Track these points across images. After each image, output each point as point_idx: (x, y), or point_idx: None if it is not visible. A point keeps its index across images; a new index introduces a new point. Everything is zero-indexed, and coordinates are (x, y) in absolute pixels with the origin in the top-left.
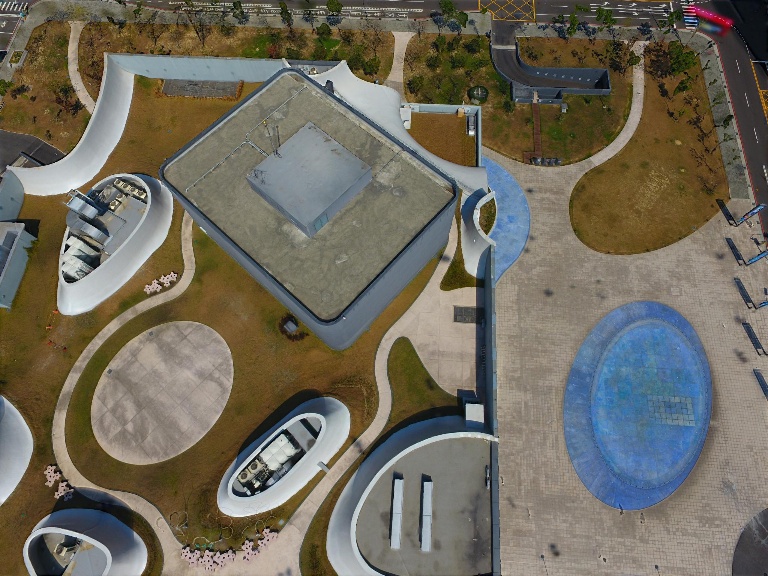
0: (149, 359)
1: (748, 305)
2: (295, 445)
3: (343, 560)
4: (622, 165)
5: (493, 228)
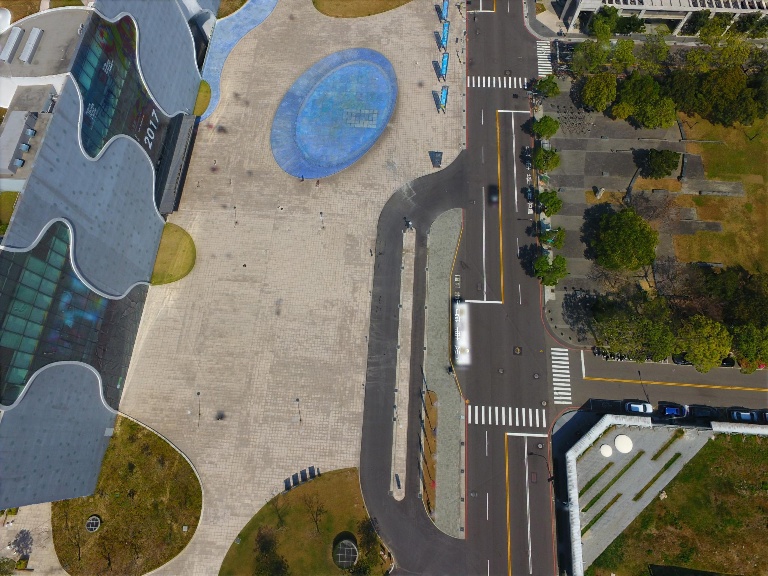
0: None
1: (440, 49)
2: None
3: None
4: None
5: (248, 2)
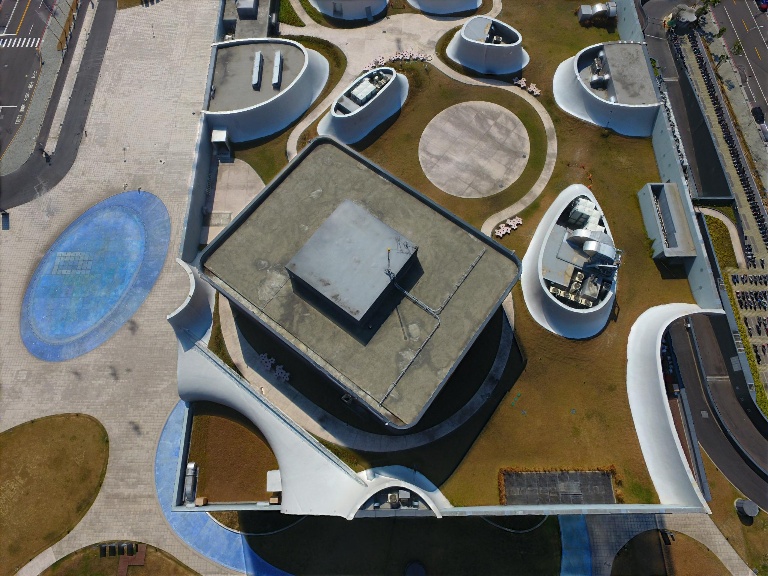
0: (495, 167)
1: None
2: (352, 98)
3: (316, 55)
4: (17, 551)
5: None
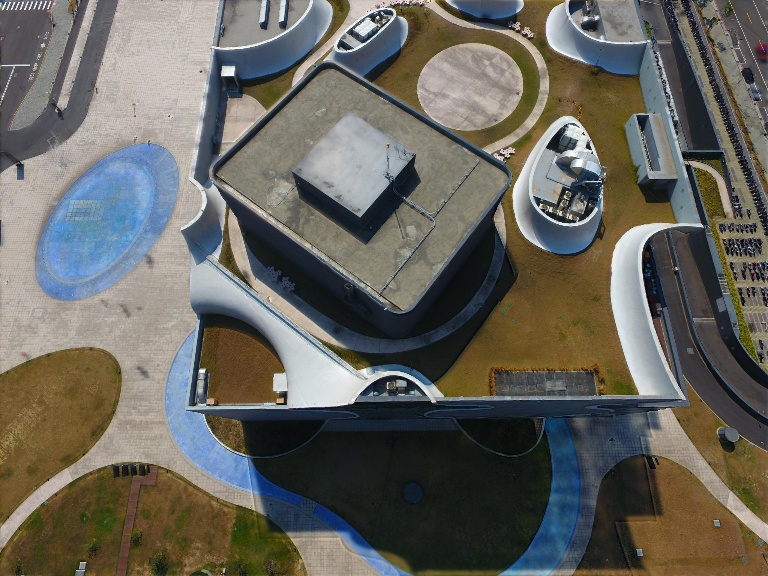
0: (490, 103)
1: None
2: (355, 35)
3: None
4: (35, 472)
5: None
